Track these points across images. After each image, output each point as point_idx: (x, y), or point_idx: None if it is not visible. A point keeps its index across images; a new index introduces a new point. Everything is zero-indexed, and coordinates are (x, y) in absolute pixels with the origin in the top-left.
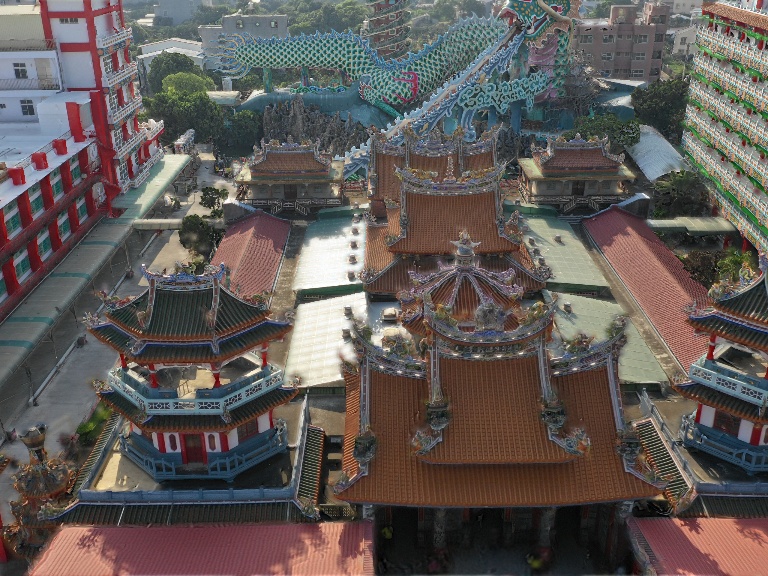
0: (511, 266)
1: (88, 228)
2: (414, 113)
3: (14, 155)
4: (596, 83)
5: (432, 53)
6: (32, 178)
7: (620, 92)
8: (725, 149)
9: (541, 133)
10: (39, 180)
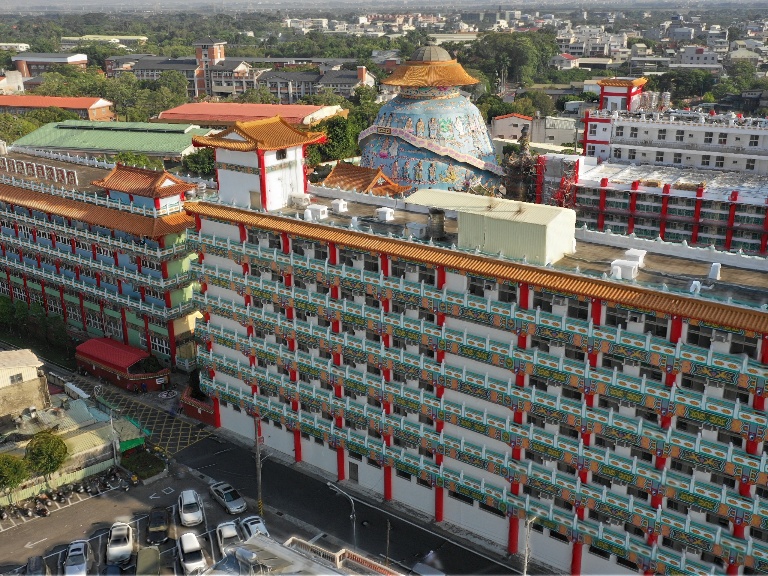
0: None
1: (764, 256)
2: None
3: (766, 196)
4: None
5: None
6: (711, 198)
7: None
8: None
9: None
10: (706, 199)
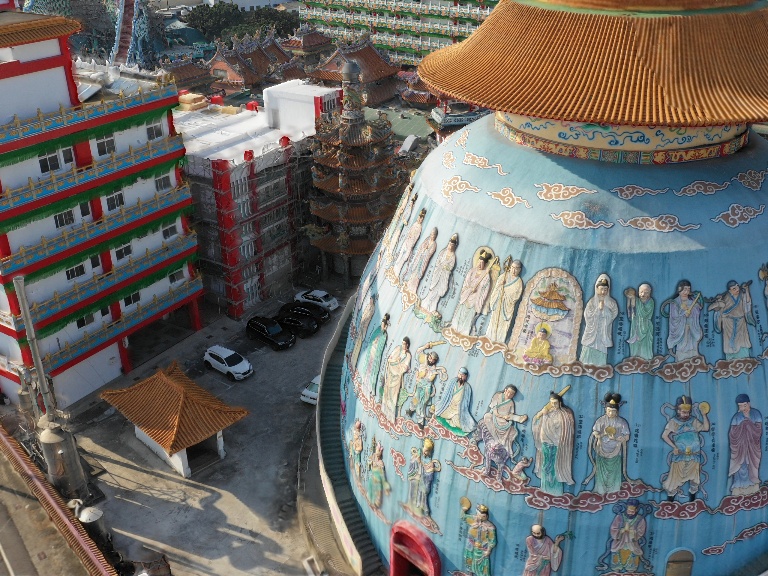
0: (399, 80)
1: None
2: (115, 47)
3: None
4: (163, 14)
5: (35, 7)
6: None
7: (167, 20)
8: (364, 22)
9: (160, 55)
10: None
